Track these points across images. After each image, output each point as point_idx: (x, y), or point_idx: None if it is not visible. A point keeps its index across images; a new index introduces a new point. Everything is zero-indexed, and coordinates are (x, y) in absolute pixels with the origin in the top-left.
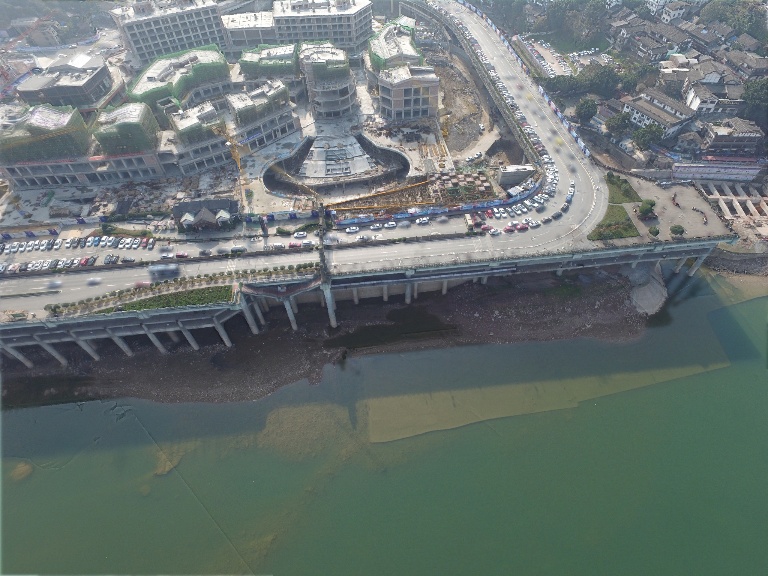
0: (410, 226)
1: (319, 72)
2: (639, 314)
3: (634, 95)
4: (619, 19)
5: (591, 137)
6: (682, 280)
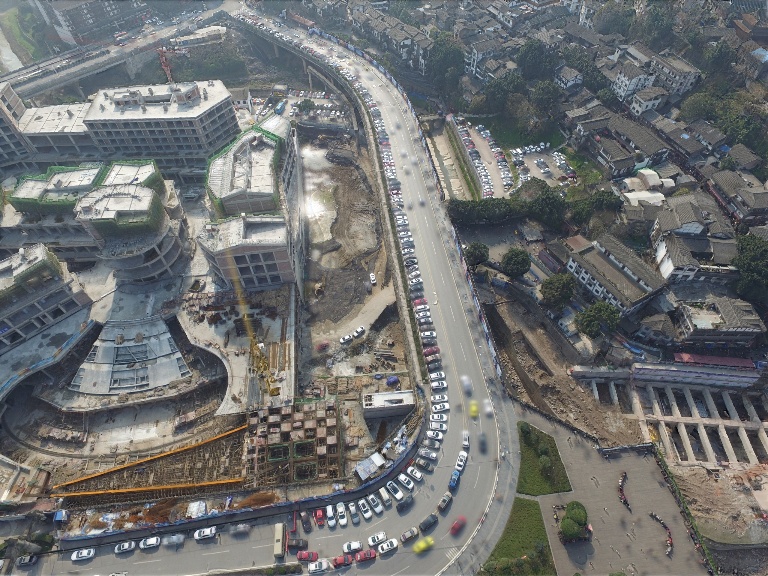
0: (183, 545)
1: (106, 230)
2: None
3: (587, 232)
4: (577, 105)
5: (523, 299)
6: None
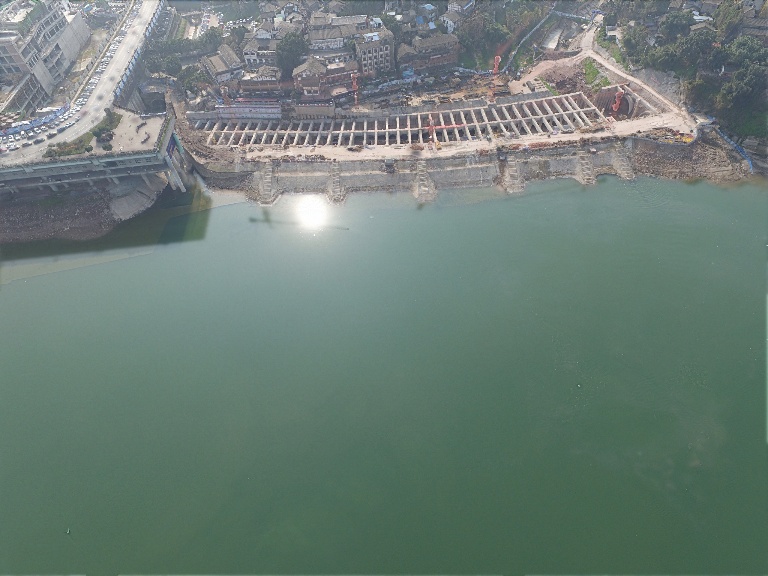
0: None
1: None
2: (114, 220)
3: None
4: None
5: (180, 88)
6: (174, 195)
